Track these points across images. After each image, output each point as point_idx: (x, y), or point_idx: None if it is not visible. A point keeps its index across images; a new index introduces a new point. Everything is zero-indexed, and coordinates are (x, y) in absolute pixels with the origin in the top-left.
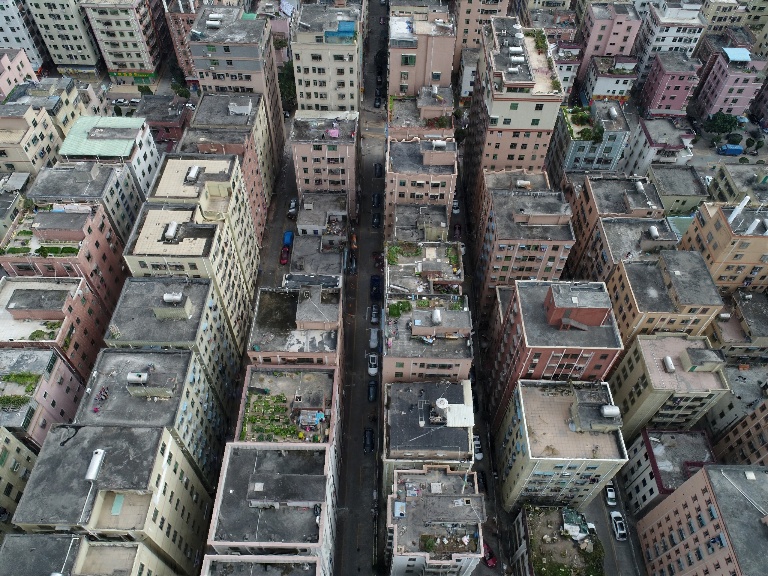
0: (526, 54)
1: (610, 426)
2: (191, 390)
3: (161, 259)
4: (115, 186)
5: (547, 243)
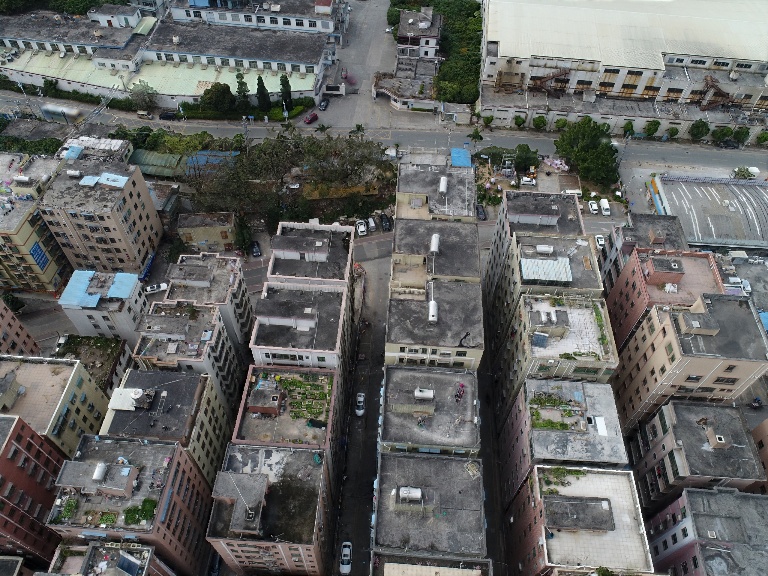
0: None
1: None
2: None
3: (439, 557)
4: None
5: None
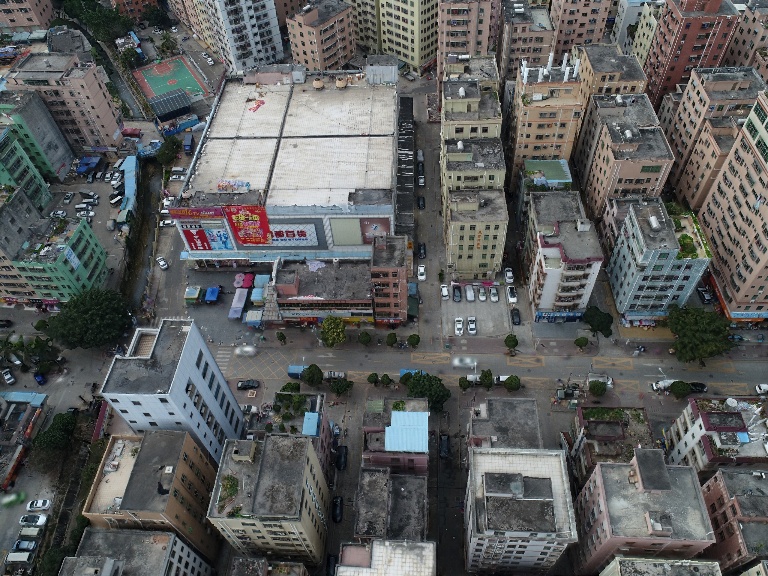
0: None
1: None
2: None
3: None
4: None
5: None
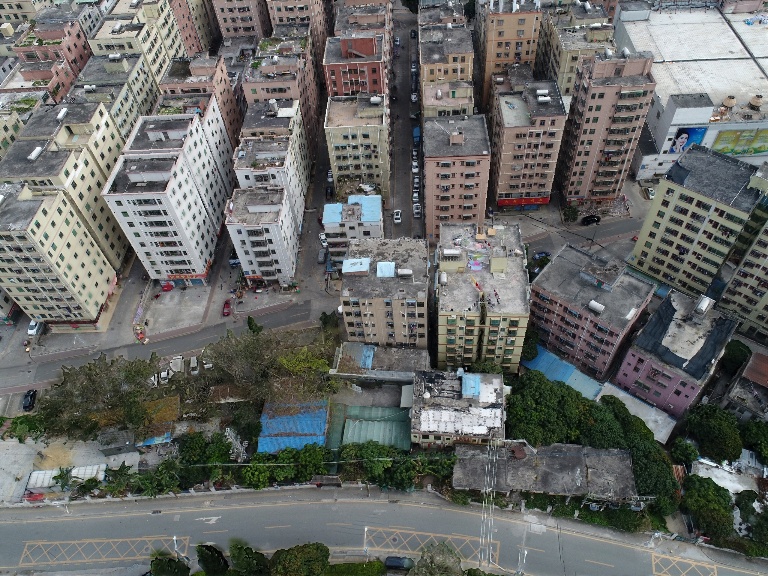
0: None
1: (376, 109)
2: (125, 105)
3: (110, 41)
4: (88, 16)
5: None
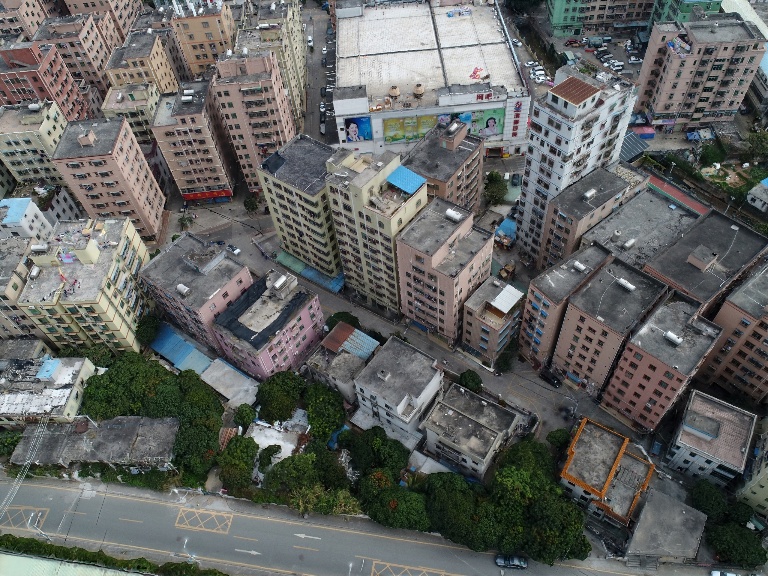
0: None
1: (35, 116)
2: None
3: None
4: None
5: (63, 41)
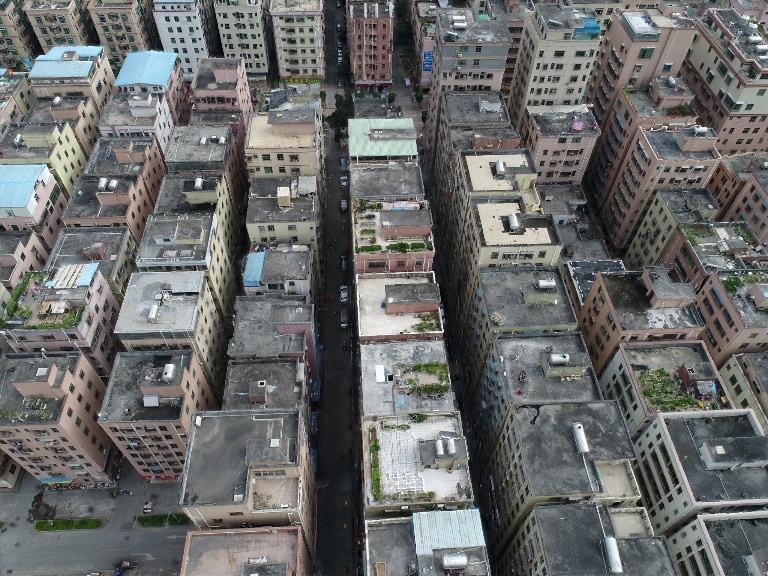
0: (764, 43)
1: None
2: None
3: (516, 249)
4: None
5: None
